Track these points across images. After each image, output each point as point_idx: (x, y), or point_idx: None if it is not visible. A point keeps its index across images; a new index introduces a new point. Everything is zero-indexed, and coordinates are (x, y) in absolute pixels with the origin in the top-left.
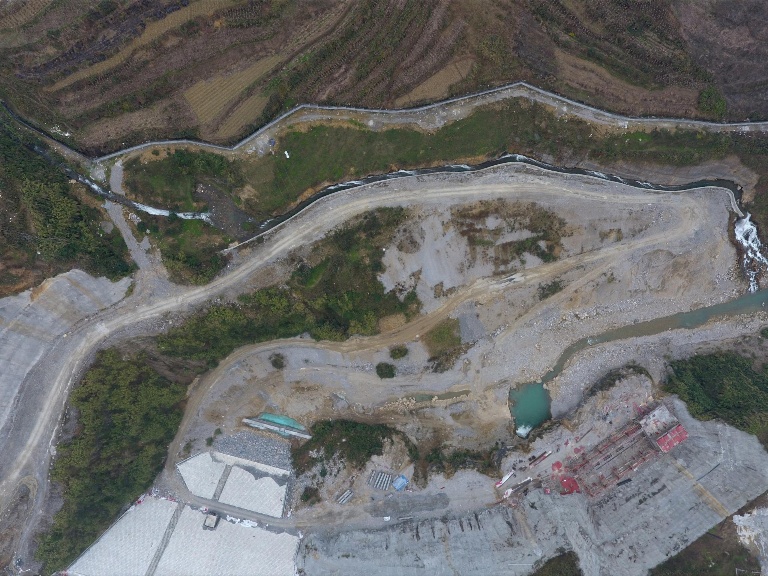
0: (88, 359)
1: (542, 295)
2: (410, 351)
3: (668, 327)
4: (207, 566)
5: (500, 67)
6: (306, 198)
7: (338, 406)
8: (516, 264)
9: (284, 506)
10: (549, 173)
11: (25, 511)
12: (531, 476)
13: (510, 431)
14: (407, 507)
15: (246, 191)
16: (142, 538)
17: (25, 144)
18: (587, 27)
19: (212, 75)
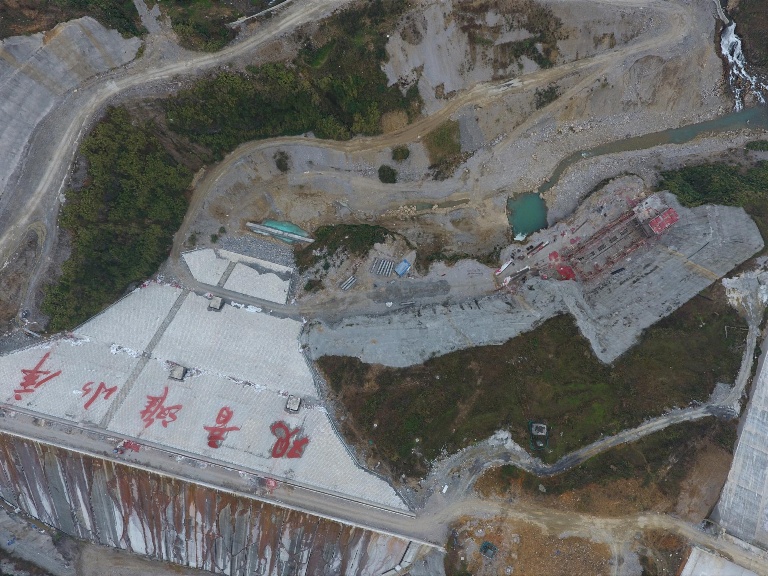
0: (98, 113)
1: (539, 103)
2: (412, 153)
3: (658, 142)
4: (212, 338)
5: None
6: None
7: (341, 213)
8: (514, 69)
9: (288, 296)
10: None
11: (33, 259)
12: (529, 265)
13: (508, 237)
14: (409, 293)
15: None
16: (147, 313)
17: None
18: None
19: None
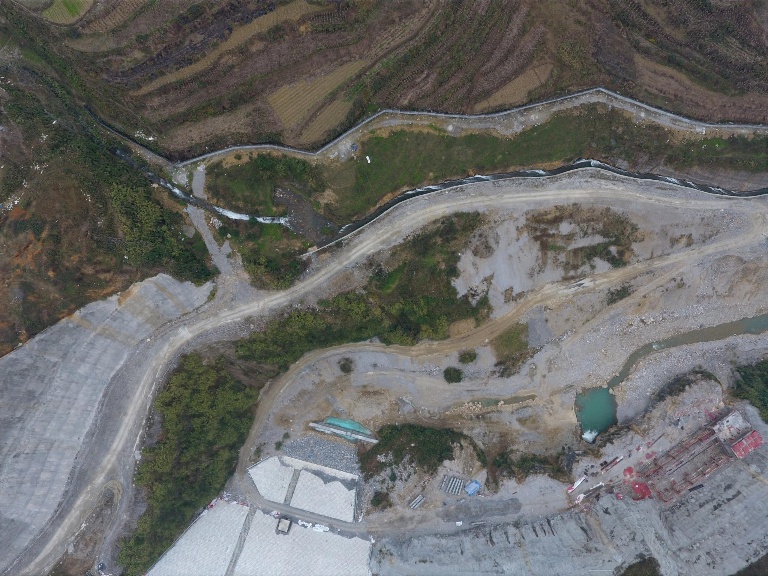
0: (172, 363)
1: (610, 300)
2: (479, 356)
3: (733, 332)
4: (283, 571)
5: (579, 73)
6: (385, 203)
7: (404, 410)
8: (586, 269)
9: (355, 511)
10: (623, 178)
11: (109, 516)
12: (603, 481)
13: (576, 436)
14: (479, 512)
15: (326, 196)
16: (217, 542)
17: (108, 148)
18: (668, 33)
19: (296, 80)
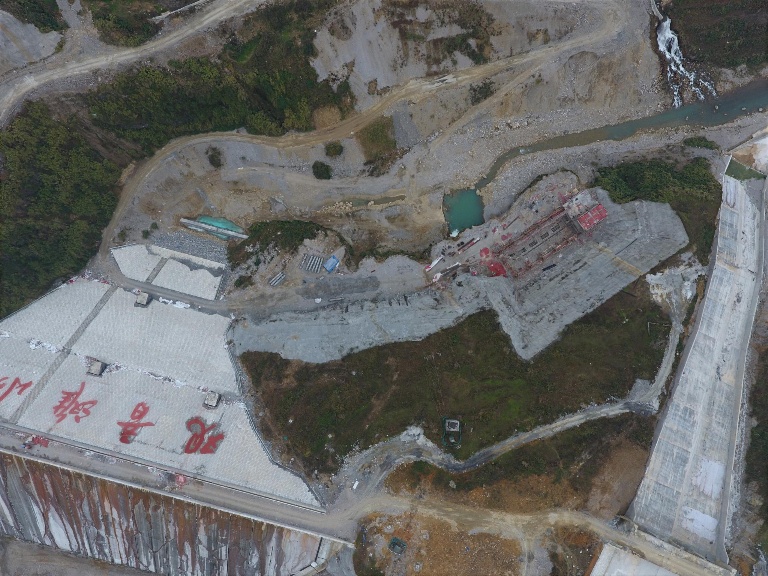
0: (15, 107)
1: (474, 99)
2: (345, 149)
3: (597, 139)
4: (136, 333)
5: None
6: None
7: (276, 209)
8: (448, 64)
9: (217, 292)
10: None
11: None
12: (460, 261)
13: (444, 234)
14: (338, 289)
15: None
16: (72, 308)
17: None
18: None
19: None
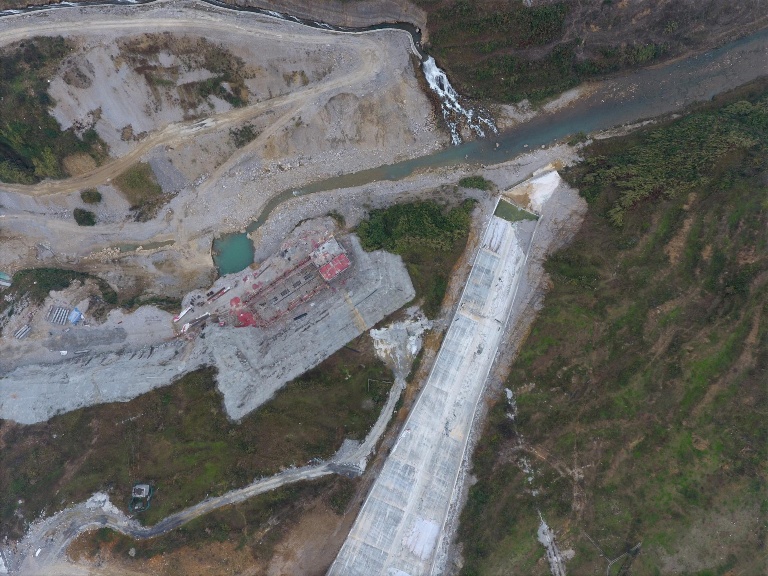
0: None
1: (237, 142)
2: (104, 196)
3: (373, 179)
4: None
5: None
6: None
7: (43, 256)
8: (205, 108)
9: None
10: (222, 11)
11: None
12: (209, 311)
13: (212, 279)
14: (84, 341)
15: None
16: None
17: None
18: None
19: None
